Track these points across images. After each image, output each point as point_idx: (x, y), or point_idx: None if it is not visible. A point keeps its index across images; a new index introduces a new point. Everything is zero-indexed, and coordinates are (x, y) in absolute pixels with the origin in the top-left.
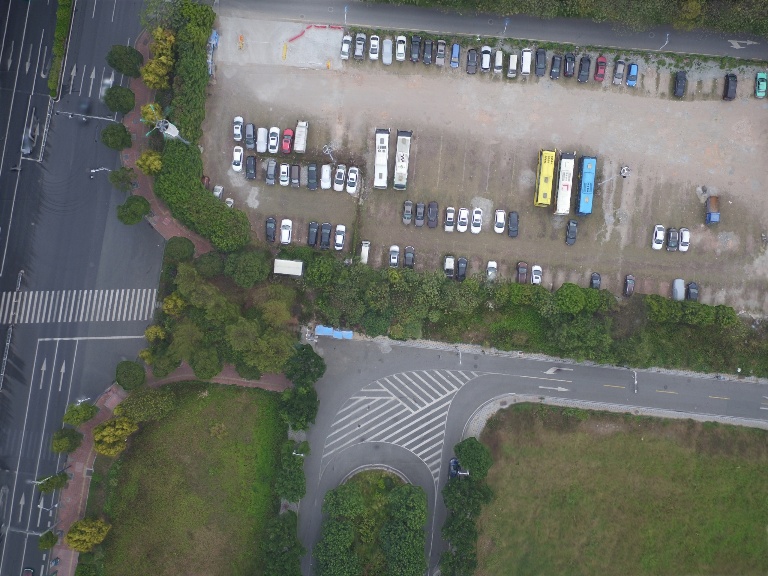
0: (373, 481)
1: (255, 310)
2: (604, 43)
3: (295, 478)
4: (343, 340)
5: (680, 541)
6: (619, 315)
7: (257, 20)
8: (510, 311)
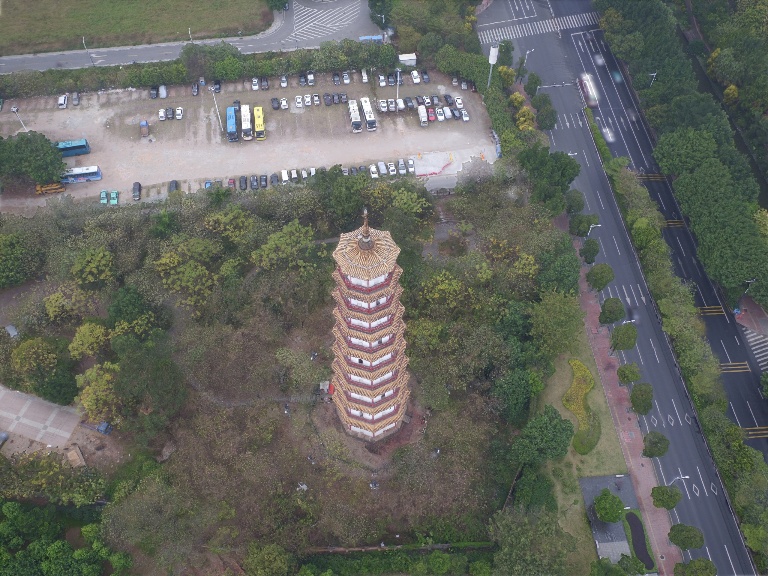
0: None
1: None
2: None
3: None
4: None
5: (151, 1)
6: None
7: None
8: None
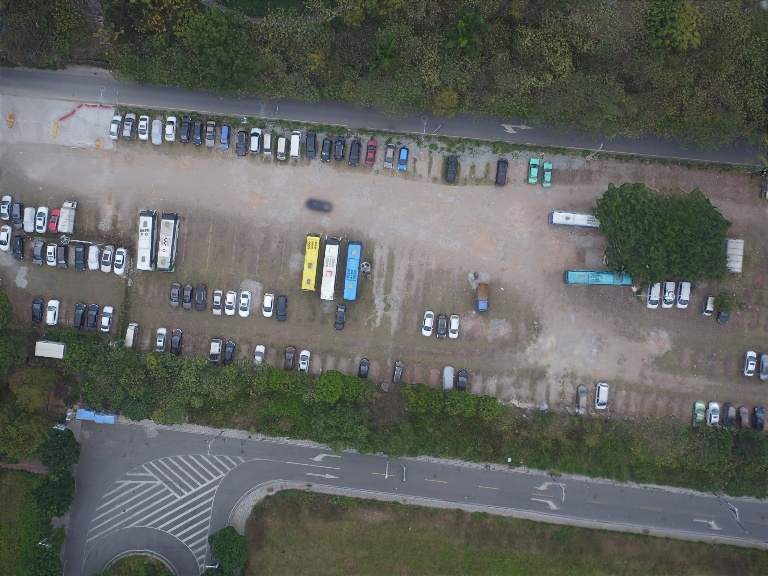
0: (136, 567)
1: (13, 394)
2: (376, 126)
3: (48, 566)
4: (106, 424)
5: None
6: (374, 407)
7: (29, 98)
8: (278, 396)
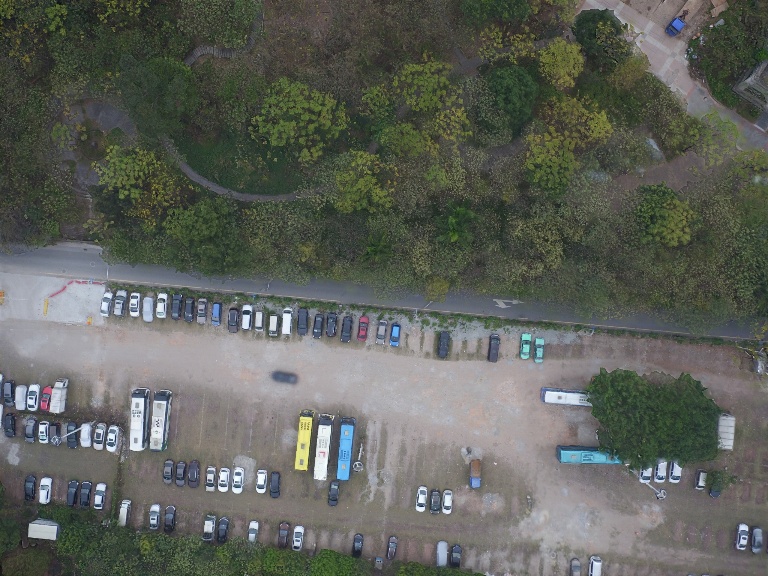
0: None
1: None
2: (368, 301)
3: None
4: None
5: None
6: None
7: (19, 274)
8: (272, 572)
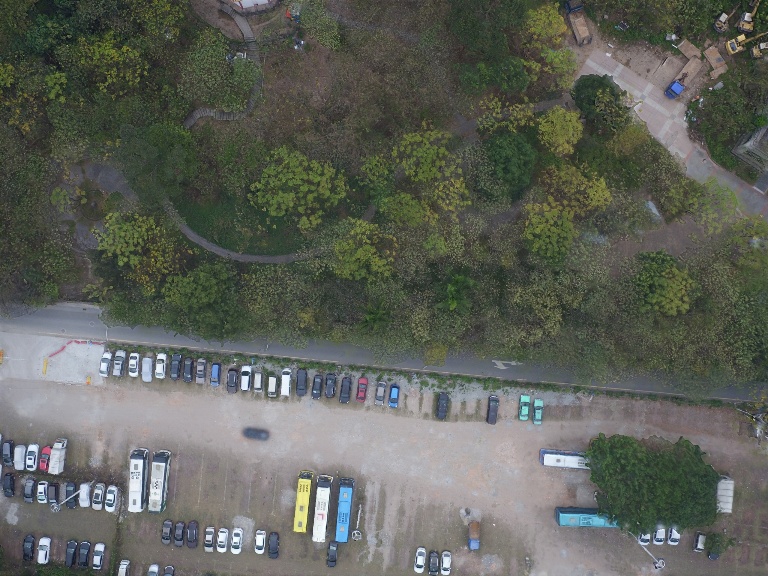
0: None
1: None
2: (367, 362)
3: None
4: None
5: None
6: None
7: (18, 334)
8: None
